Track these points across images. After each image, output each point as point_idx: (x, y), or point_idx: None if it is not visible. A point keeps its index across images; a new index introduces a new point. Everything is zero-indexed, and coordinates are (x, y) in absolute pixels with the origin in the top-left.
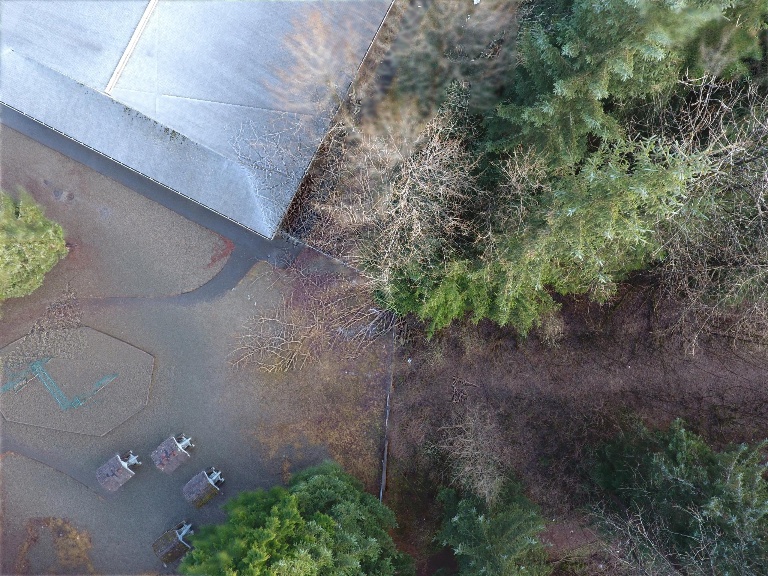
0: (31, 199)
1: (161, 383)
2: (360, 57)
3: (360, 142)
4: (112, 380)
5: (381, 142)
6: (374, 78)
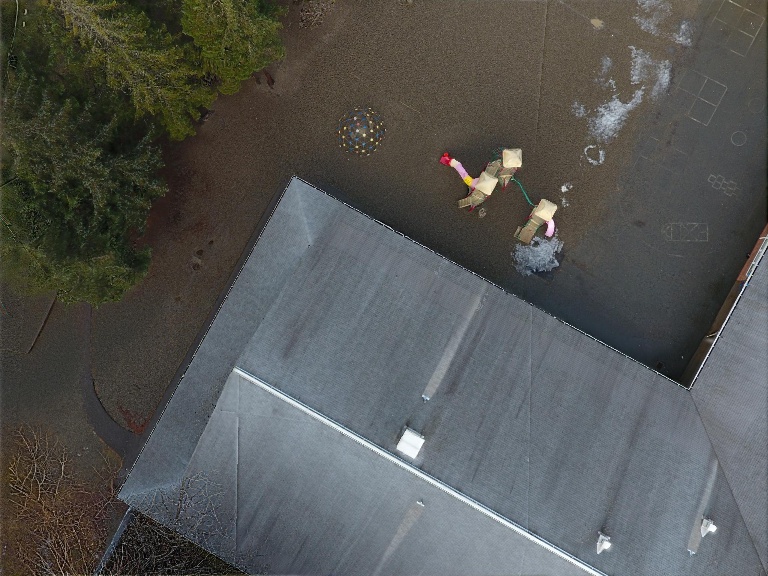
0: (195, 227)
1: (4, 358)
2: None
3: (237, 569)
4: (7, 311)
5: None
6: None
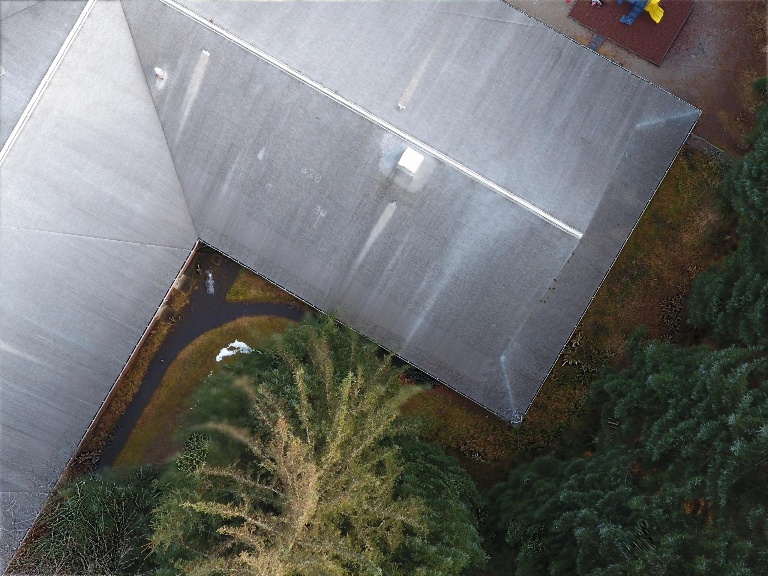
0: None
1: None
2: (80, 435)
3: (97, 490)
4: None
5: (118, 490)
6: (115, 428)
